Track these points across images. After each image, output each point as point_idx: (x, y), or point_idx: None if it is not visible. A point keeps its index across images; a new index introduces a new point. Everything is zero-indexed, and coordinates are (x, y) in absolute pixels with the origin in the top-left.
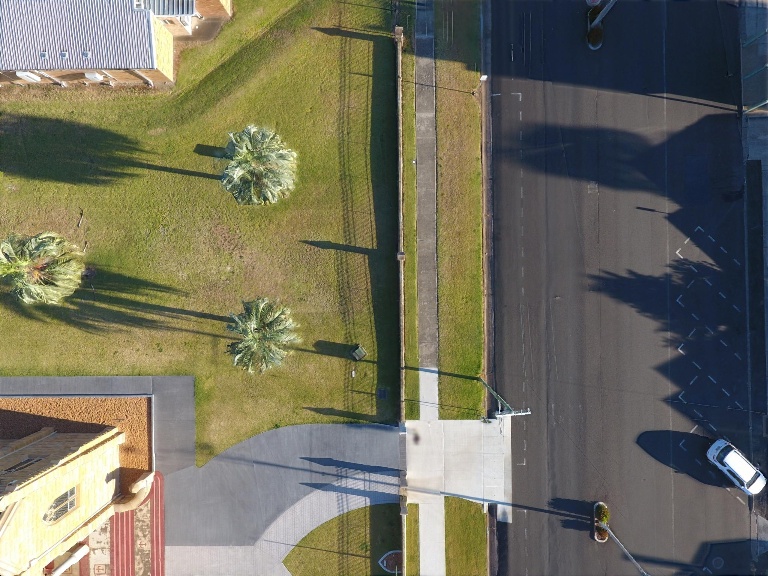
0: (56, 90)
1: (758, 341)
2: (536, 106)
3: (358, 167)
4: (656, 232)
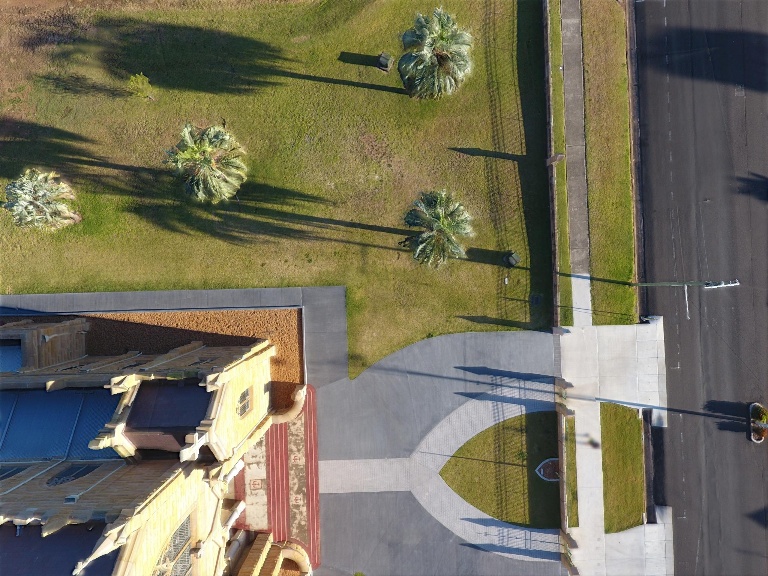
0: None
1: None
2: (681, 11)
3: (505, 73)
4: None
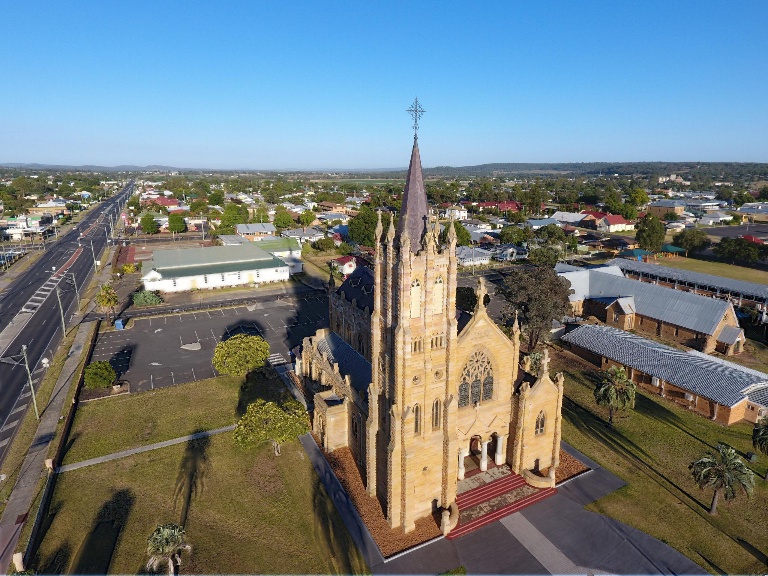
0: (657, 395)
1: None
2: None
3: None
4: None
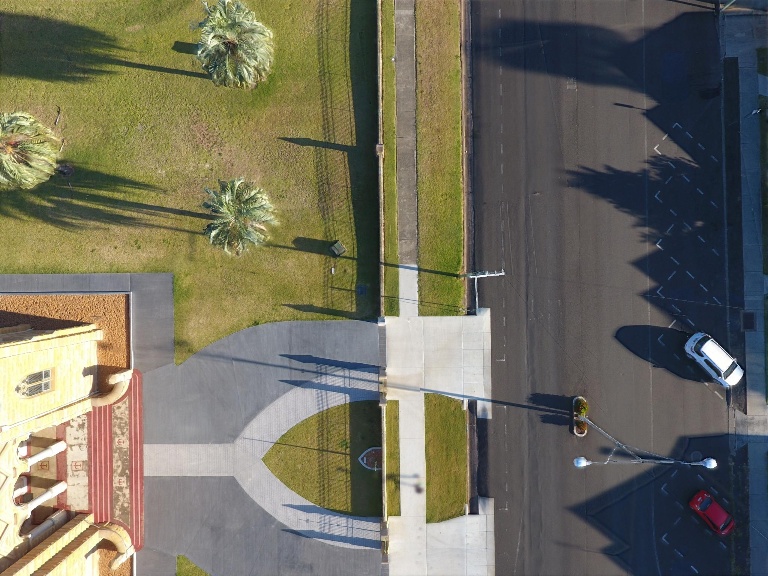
0: None
1: (735, 237)
2: (515, 3)
3: (337, 64)
4: (634, 128)
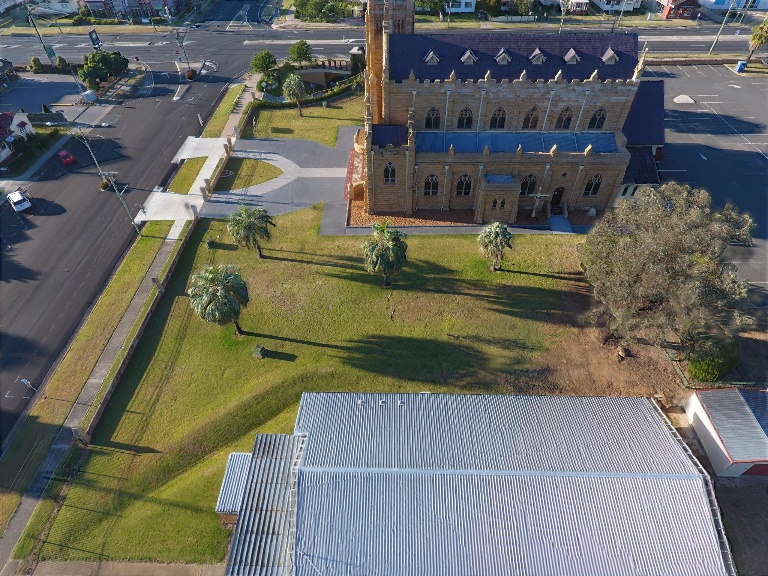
0: None
1: None
2: None
3: (168, 344)
4: None
